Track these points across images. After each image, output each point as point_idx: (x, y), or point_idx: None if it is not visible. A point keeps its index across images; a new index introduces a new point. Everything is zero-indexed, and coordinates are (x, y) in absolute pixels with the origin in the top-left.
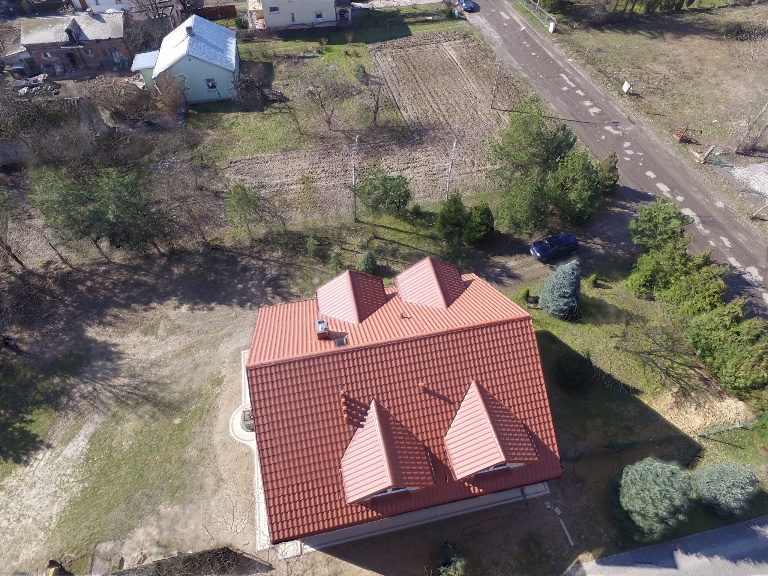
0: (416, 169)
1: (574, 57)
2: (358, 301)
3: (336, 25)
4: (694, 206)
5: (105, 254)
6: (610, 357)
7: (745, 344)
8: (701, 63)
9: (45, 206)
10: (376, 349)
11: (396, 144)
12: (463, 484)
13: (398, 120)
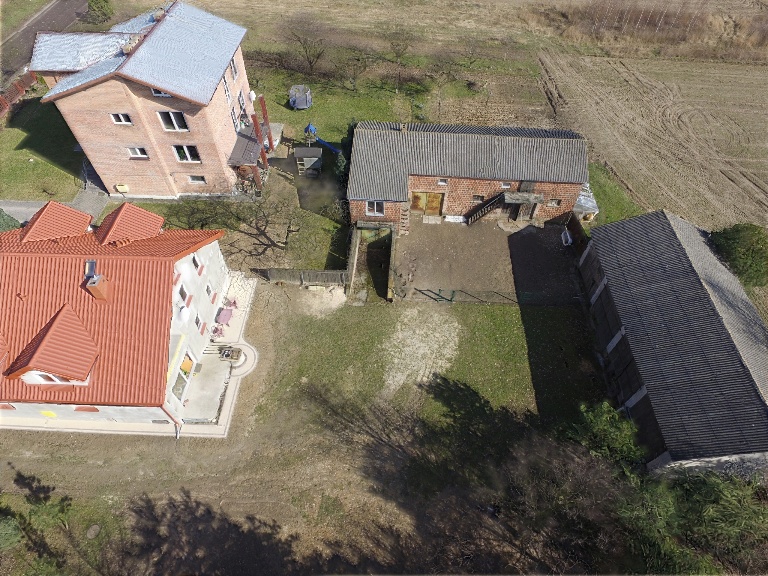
0: None
1: None
2: None
3: None
4: None
5: None
6: None
7: None
8: None
9: None
10: None
11: None
12: None
13: None
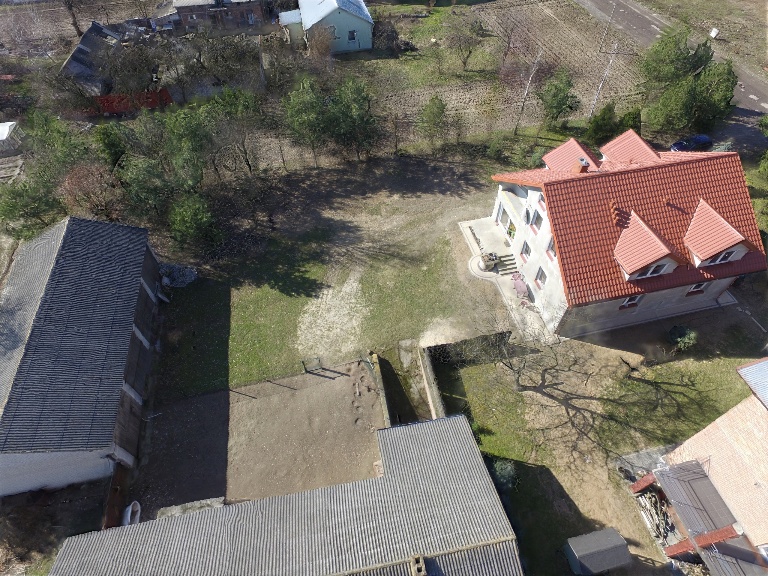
0: None
1: (658, 12)
2: (589, 156)
3: None
4: None
5: (311, 162)
6: (759, 219)
7: None
8: None
9: (296, 108)
10: (631, 174)
11: (526, 80)
12: (699, 271)
13: None
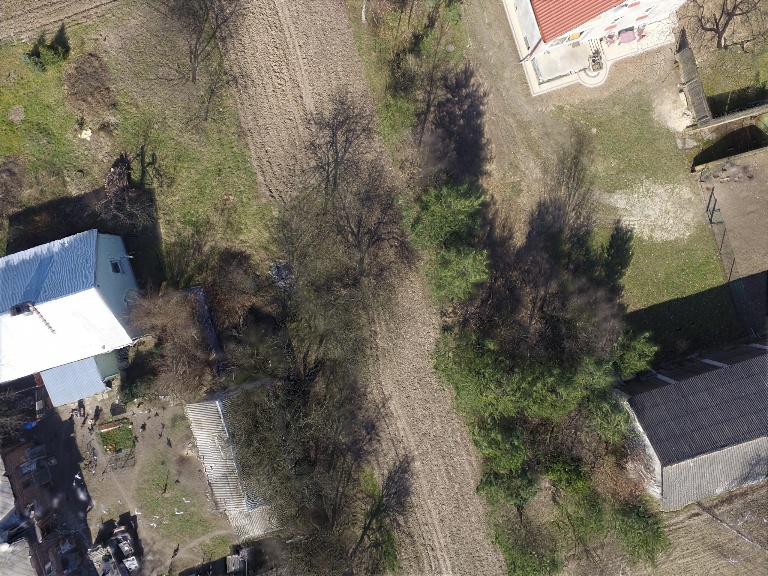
0: None
1: None
2: None
3: None
4: None
5: None
6: None
7: None
8: None
9: None
10: None
11: None
12: None
13: None
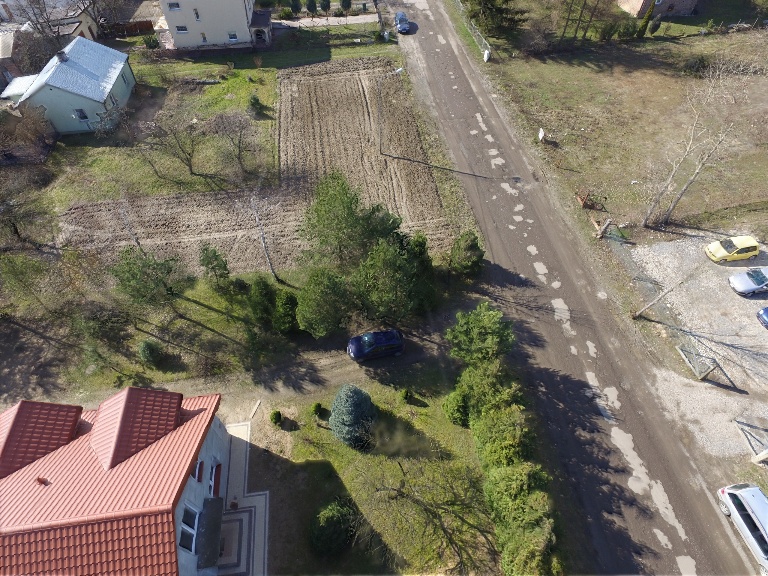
0: (265, 228)
1: (500, 92)
2: (9, 449)
3: (252, 46)
4: (570, 296)
5: None
6: (388, 508)
7: (526, 527)
8: (644, 105)
9: None
10: None
11: (257, 195)
12: None
13: (271, 164)
